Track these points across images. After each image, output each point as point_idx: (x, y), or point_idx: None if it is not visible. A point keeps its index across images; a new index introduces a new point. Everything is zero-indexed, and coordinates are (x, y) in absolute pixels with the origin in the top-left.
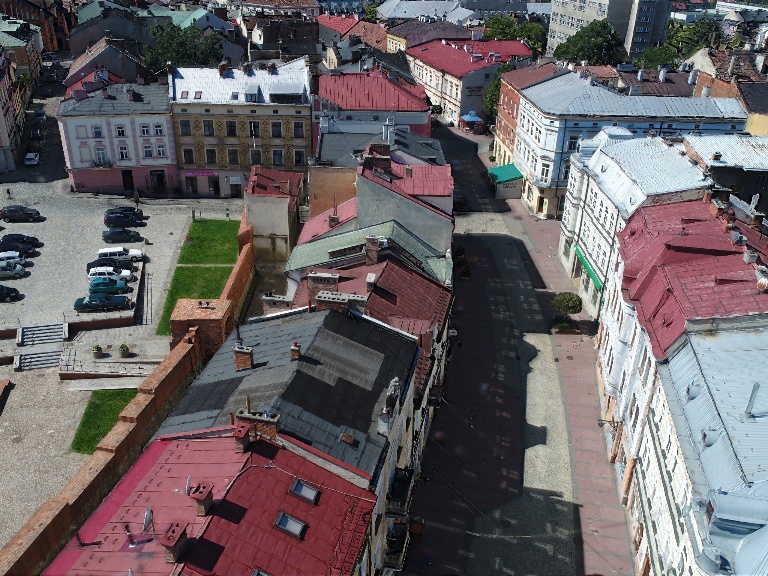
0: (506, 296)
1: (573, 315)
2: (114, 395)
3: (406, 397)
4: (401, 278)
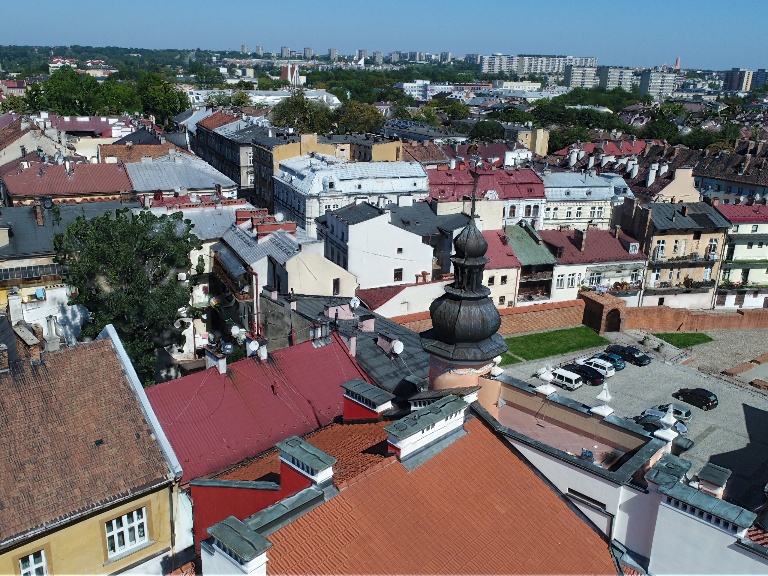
0: None
1: None
2: None
3: None
4: None
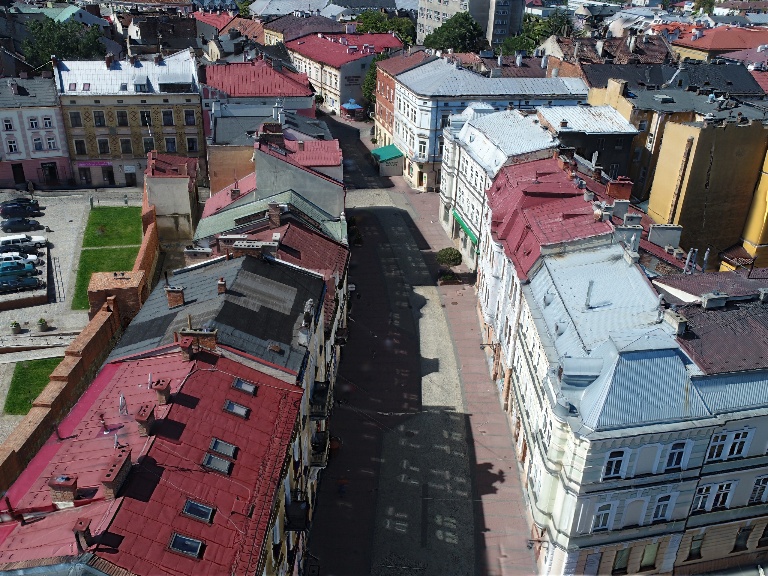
0: (396, 258)
1: (455, 269)
2: (38, 364)
3: (318, 324)
4: (303, 238)
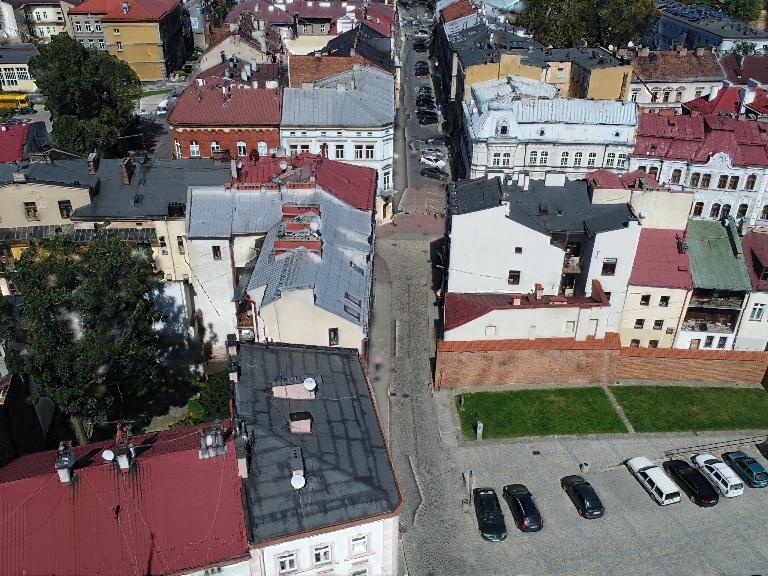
0: None
1: None
2: None
3: None
4: None
